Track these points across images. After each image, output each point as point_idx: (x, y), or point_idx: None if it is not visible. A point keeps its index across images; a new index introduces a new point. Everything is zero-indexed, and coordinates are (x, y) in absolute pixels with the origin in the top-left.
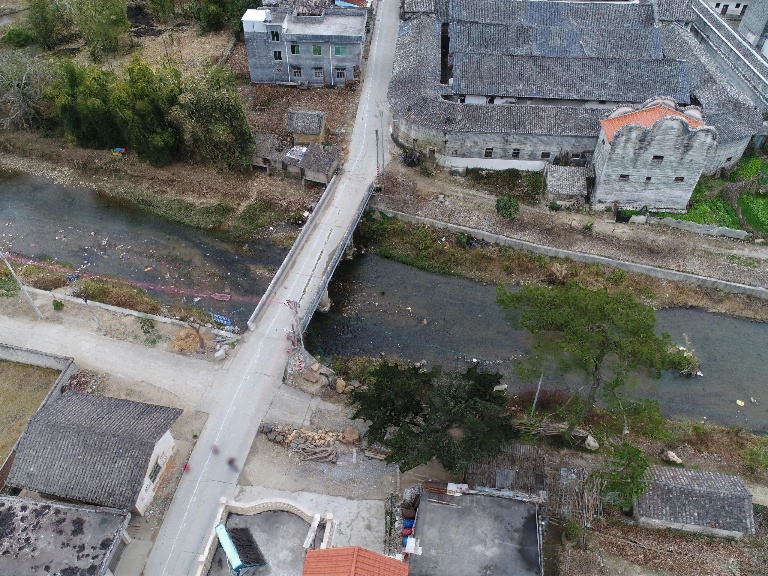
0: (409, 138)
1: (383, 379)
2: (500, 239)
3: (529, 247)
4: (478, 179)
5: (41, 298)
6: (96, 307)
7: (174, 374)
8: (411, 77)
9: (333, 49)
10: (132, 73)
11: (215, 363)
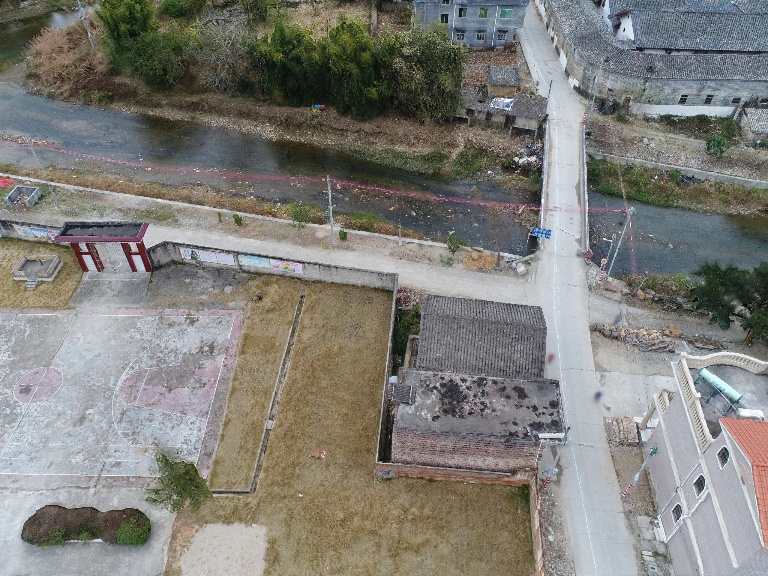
0: (603, 88)
1: (713, 276)
2: (711, 175)
3: (741, 182)
4: (673, 124)
5: (321, 231)
6: (376, 237)
7: (485, 288)
8: (594, 33)
9: (499, 12)
10: (342, 30)
11: (518, 278)
